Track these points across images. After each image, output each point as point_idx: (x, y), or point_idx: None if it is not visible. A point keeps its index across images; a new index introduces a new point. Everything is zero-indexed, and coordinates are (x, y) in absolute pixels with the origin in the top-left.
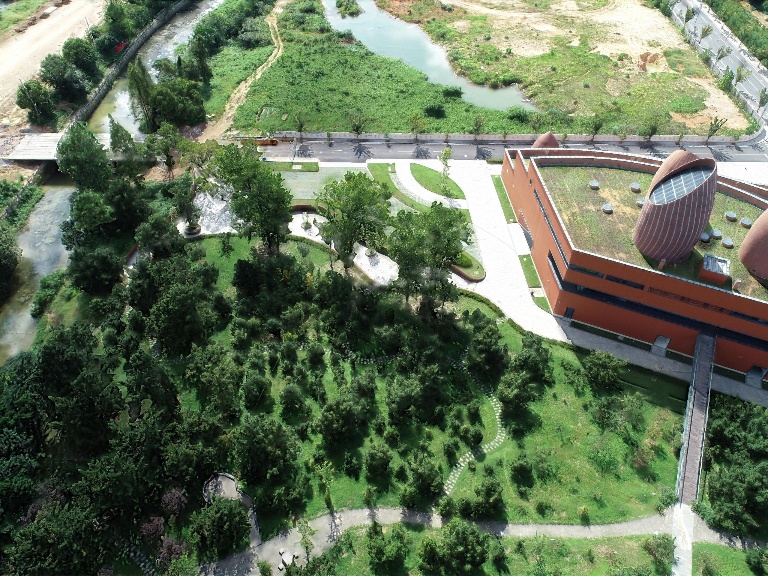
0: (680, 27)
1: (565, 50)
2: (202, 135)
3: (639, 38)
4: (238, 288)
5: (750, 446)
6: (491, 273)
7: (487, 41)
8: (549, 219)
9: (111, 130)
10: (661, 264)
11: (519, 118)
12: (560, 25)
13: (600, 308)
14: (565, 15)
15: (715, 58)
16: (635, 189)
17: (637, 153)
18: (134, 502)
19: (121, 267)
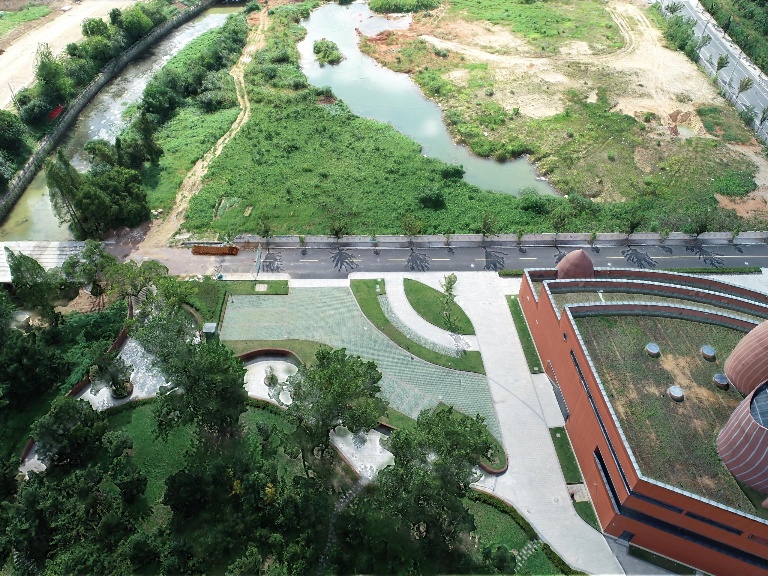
0: (711, 76)
1: (581, 108)
2: (144, 241)
3: (665, 91)
4: (172, 506)
5: None
6: (515, 460)
7: (490, 97)
8: (596, 406)
9: (11, 265)
10: (767, 503)
11: (535, 208)
12: (573, 74)
13: (672, 540)
14: (577, 61)
15: (757, 117)
16: (708, 356)
17: (683, 257)
18: None
19: (11, 478)
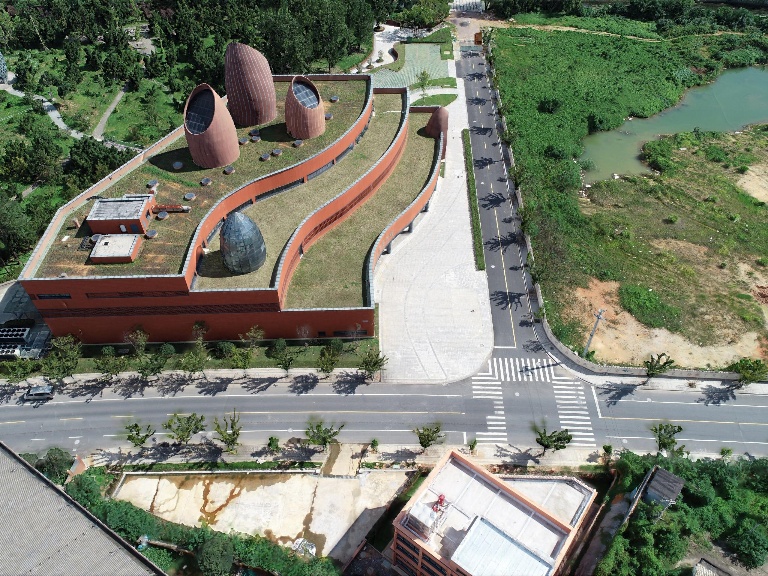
0: None
1: None
2: (484, 20)
3: None
4: None
5: (104, 146)
6: None
7: None
8: None
9: None
10: None
11: (549, 152)
12: None
13: None
14: None
15: None
16: (325, 115)
17: (498, 227)
18: (172, 5)
19: None
